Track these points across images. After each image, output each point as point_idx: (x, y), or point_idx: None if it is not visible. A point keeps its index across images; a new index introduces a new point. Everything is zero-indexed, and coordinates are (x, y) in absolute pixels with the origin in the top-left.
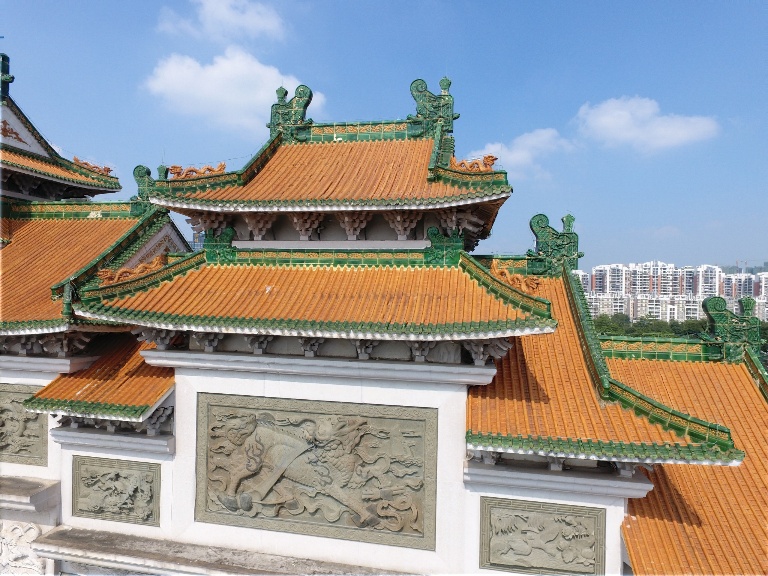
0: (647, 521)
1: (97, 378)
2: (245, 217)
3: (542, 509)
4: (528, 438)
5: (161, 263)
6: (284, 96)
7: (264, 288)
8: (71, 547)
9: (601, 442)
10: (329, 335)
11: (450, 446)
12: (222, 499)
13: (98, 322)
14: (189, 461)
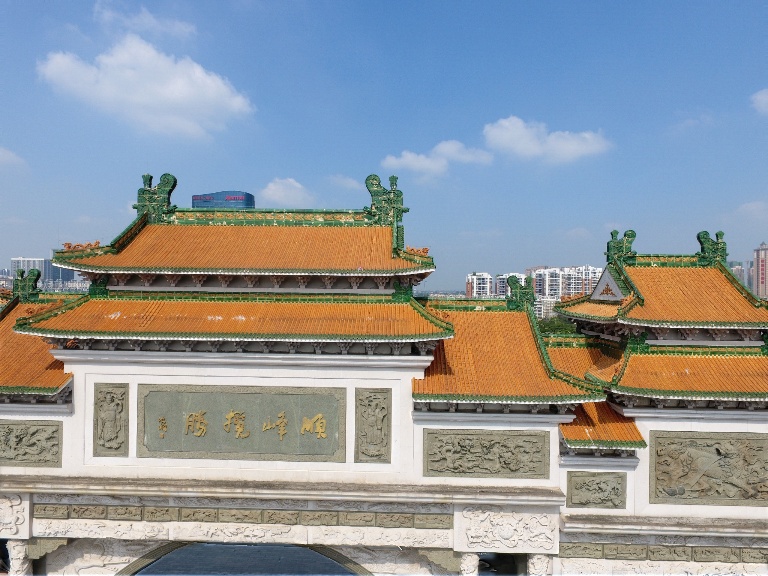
0: None
1: (587, 425)
2: None
3: None
4: None
5: None
6: (617, 236)
7: (685, 371)
8: (592, 524)
9: None
10: (754, 400)
11: None
12: (666, 490)
13: None
14: (645, 470)
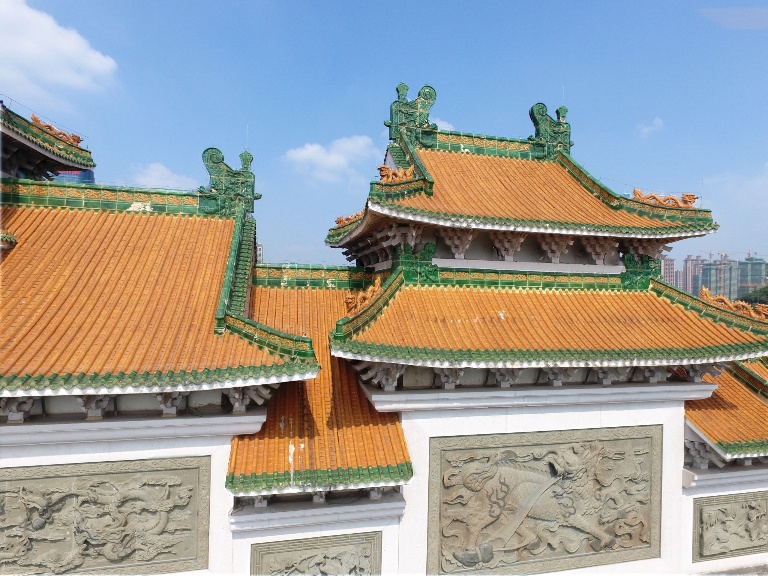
0: None
1: (297, 435)
2: (449, 232)
3: (734, 500)
4: (762, 442)
5: None
6: (406, 94)
7: (498, 314)
8: None
9: None
10: (614, 364)
11: (672, 458)
12: (459, 556)
13: None
14: (420, 520)
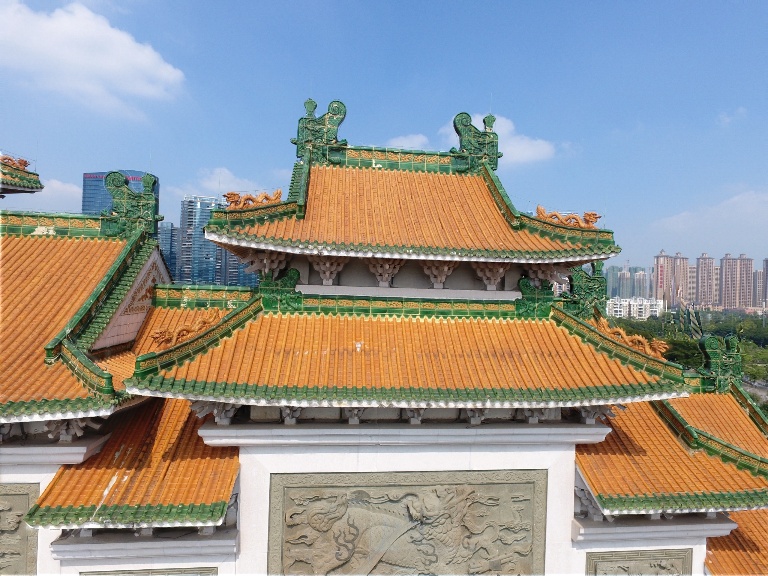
0: (721, 554)
1: (124, 467)
2: (314, 258)
3: (640, 557)
4: (655, 497)
5: (149, 297)
6: (314, 110)
7: (354, 345)
8: None
9: (714, 494)
10: (463, 405)
11: (559, 506)
12: None
13: (130, 394)
14: (258, 559)
